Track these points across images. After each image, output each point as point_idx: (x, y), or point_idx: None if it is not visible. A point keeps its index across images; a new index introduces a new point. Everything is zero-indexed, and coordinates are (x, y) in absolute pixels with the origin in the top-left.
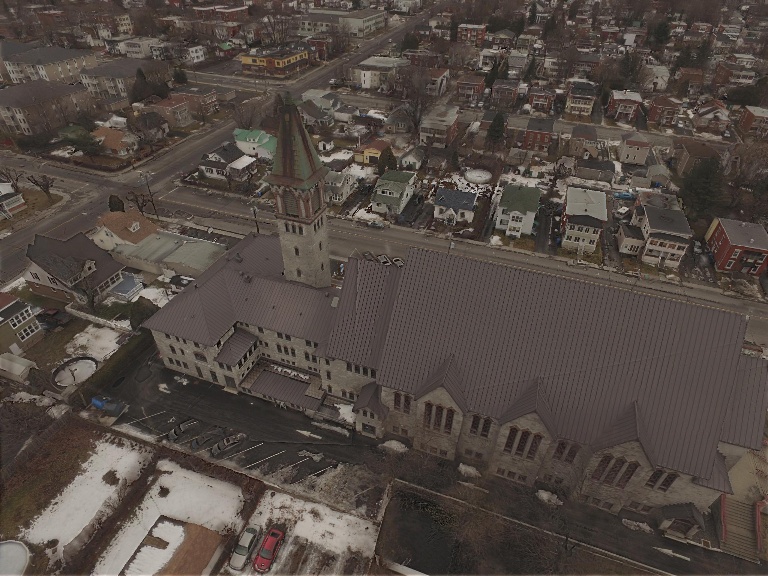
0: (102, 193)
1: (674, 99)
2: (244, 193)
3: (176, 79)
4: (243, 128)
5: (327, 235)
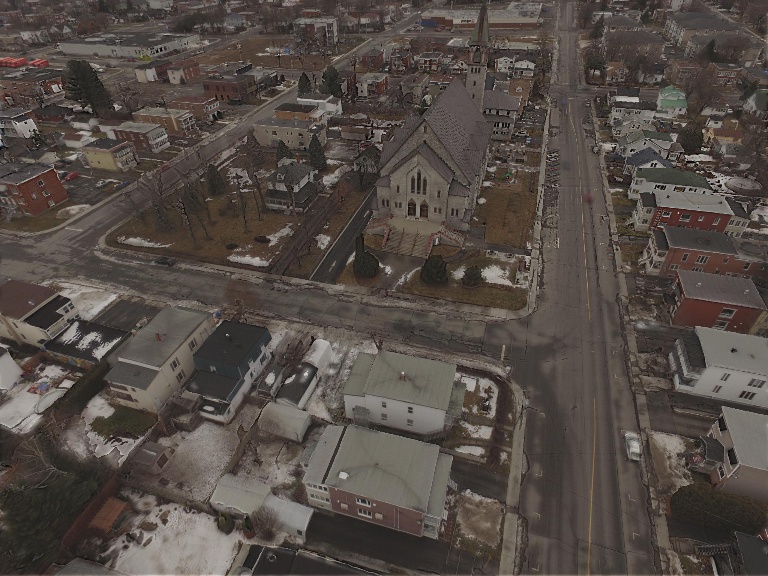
0: (561, 87)
1: None
2: (599, 113)
3: (766, 63)
4: (687, 91)
5: (483, 82)
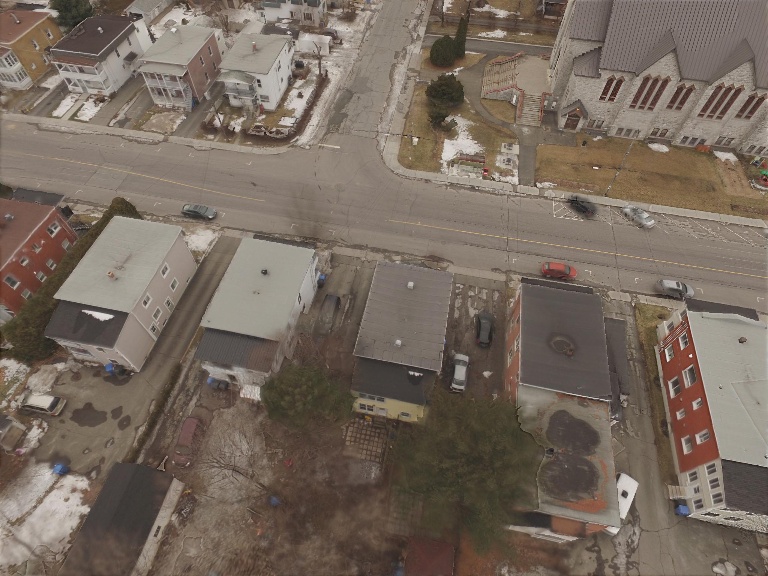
0: None
1: None
2: None
3: None
4: None
5: None
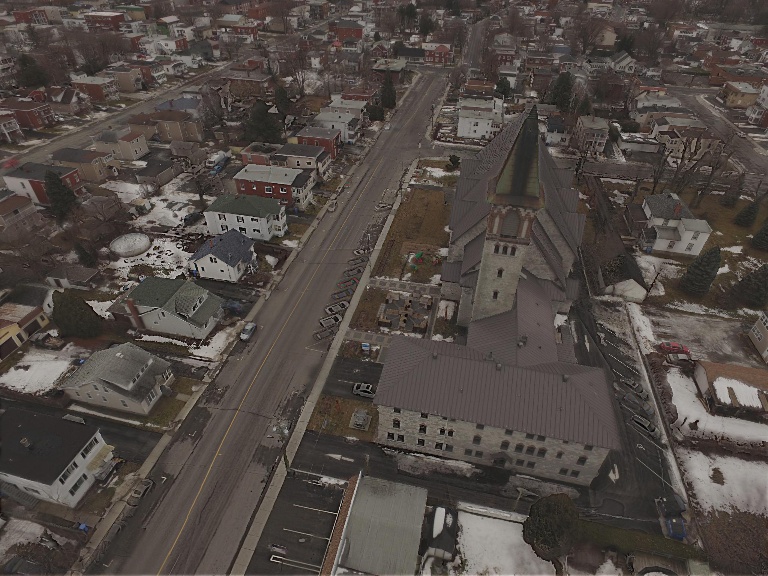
0: None
1: (23, 99)
2: None
3: None
4: None
5: None
